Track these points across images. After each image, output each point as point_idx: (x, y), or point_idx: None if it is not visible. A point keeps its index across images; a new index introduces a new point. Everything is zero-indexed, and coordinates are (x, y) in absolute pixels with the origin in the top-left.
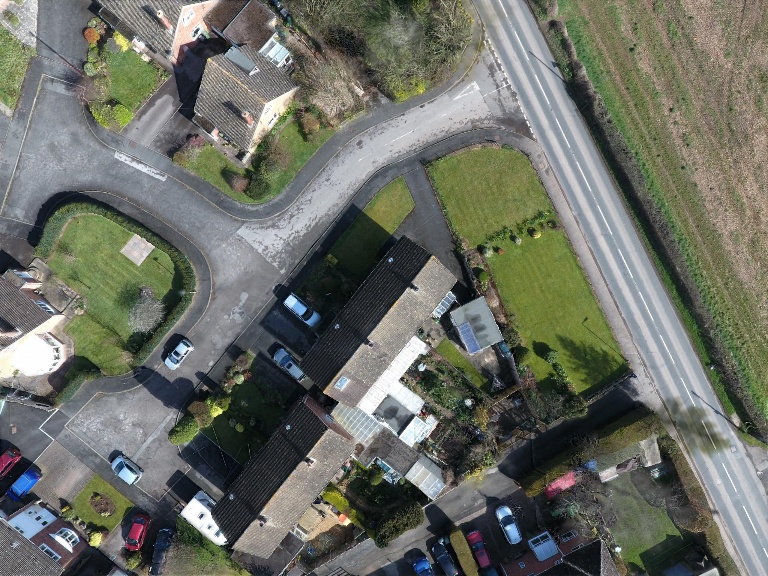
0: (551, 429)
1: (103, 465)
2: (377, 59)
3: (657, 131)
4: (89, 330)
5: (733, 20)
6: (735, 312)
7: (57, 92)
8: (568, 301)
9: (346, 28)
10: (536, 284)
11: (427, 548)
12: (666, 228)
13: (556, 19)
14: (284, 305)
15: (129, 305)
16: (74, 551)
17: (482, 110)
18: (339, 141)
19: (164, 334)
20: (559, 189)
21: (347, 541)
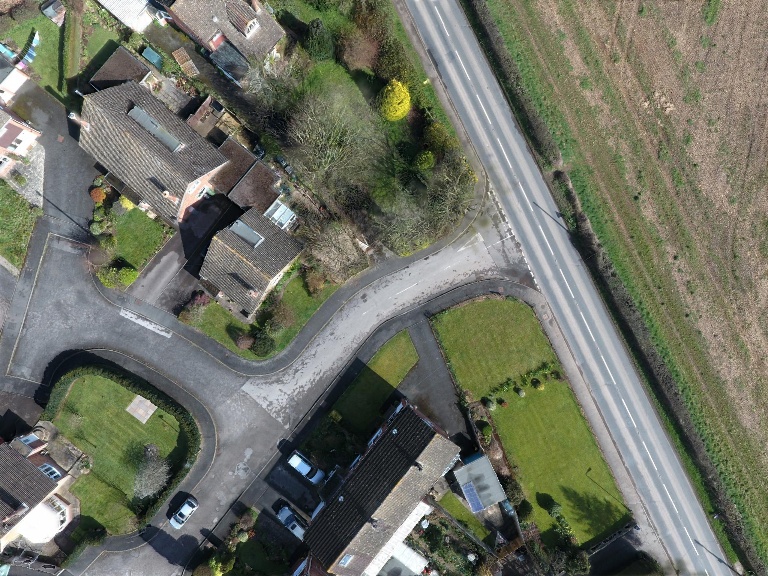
0: None
1: None
2: (381, 213)
3: (661, 279)
4: (95, 489)
5: (738, 167)
6: (739, 459)
7: (63, 250)
8: (571, 452)
9: (350, 182)
10: (539, 435)
11: None
12: (670, 381)
13: (560, 169)
14: None
15: (134, 463)
16: None
17: (486, 261)
18: (343, 295)
19: (169, 495)
20: (563, 340)
21: None
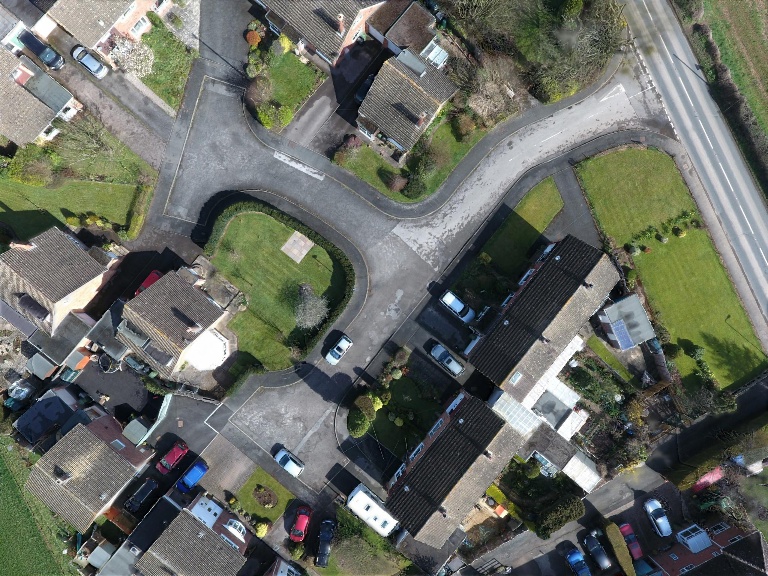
0: (695, 424)
1: (266, 458)
2: (527, 61)
3: None
4: (251, 326)
5: None
6: None
7: (218, 93)
8: (711, 299)
9: (497, 31)
10: (680, 282)
11: (578, 540)
12: None
13: (699, 23)
14: (438, 302)
15: (289, 302)
16: (245, 541)
17: (628, 112)
18: (490, 142)
19: None
20: (702, 189)
21: (502, 533)
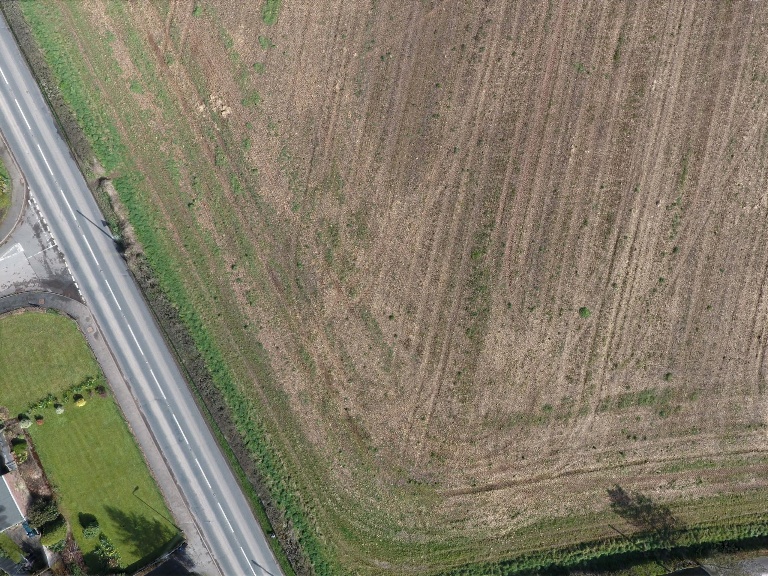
0: None
1: None
2: None
3: (217, 289)
4: None
5: (300, 172)
6: (304, 475)
7: None
8: (118, 470)
9: None
10: (83, 453)
11: None
12: (212, 396)
13: (106, 176)
14: None
15: None
16: None
17: (26, 272)
18: None
19: None
20: (109, 353)
21: None
